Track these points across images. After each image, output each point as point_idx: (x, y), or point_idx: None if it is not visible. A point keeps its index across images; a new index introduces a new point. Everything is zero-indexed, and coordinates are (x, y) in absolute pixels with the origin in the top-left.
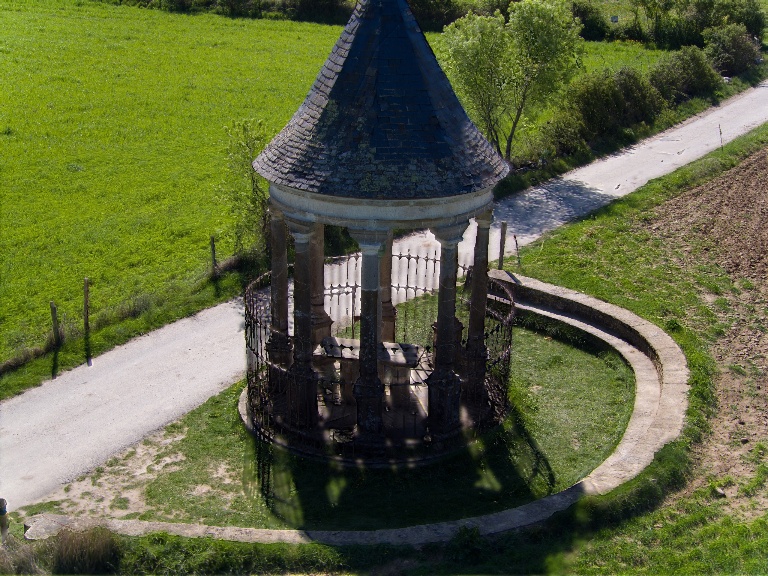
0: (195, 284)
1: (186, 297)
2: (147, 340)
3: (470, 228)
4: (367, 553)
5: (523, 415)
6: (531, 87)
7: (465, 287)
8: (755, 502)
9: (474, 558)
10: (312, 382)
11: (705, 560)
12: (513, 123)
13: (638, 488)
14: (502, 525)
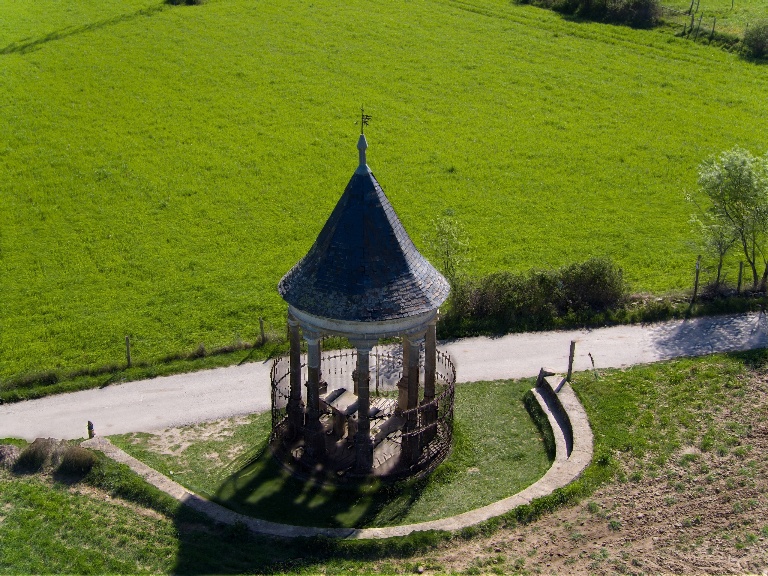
0: None
1: None
2: None
3: (632, 336)
4: (189, 514)
5: (428, 482)
6: None
7: (536, 382)
8: None
9: (230, 539)
10: (298, 413)
11: None
12: None
13: (362, 543)
14: (271, 530)
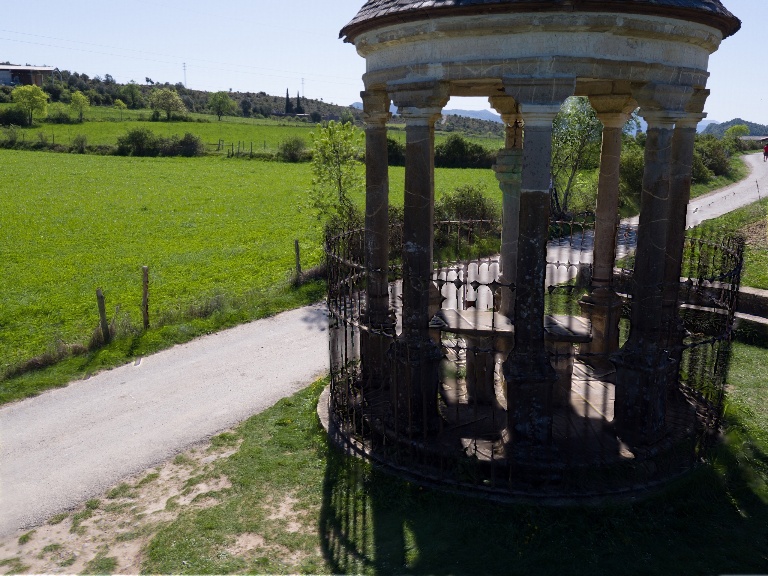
0: (277, 290)
1: (265, 299)
2: (214, 339)
3: (552, 250)
4: None
5: (743, 420)
6: (587, 143)
7: None
8: None
9: None
10: (431, 362)
11: None
12: (569, 178)
13: None
14: None
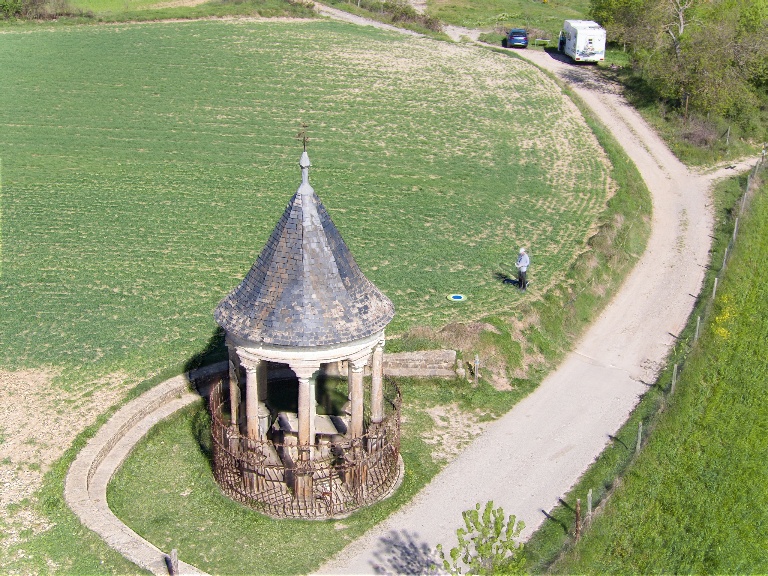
0: None
1: None
2: None
3: None
4: None
5: None
6: None
7: None
8: (108, 380)
9: None
10: None
11: None
12: None
13: None
14: None
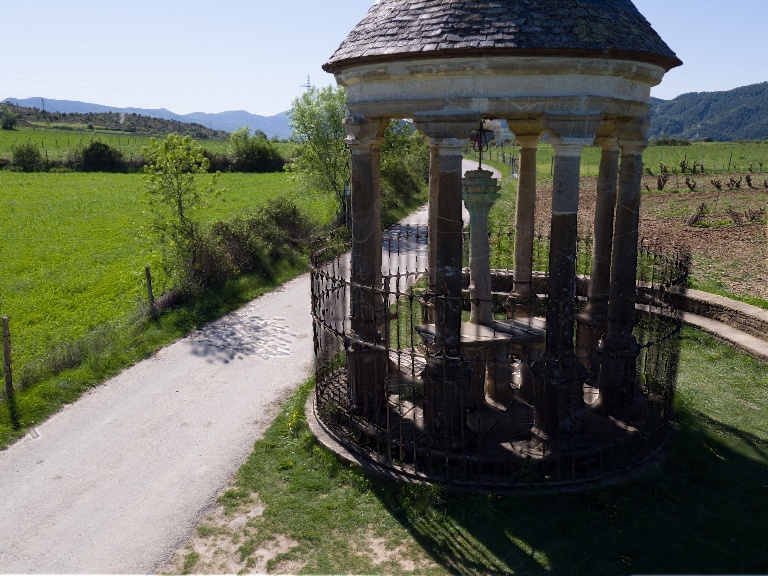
0: (135, 325)
1: None
2: (107, 391)
3: None
4: None
5: None
6: None
7: None
8: None
9: None
10: None
11: None
12: None
13: None
14: None
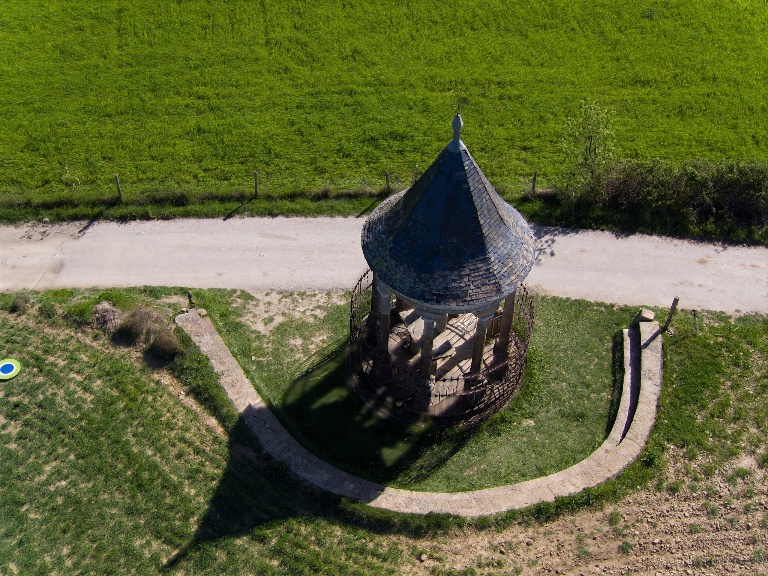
0: (511, 195)
1: None
2: None
3: (766, 267)
4: (244, 436)
5: (479, 432)
6: None
7: None
8: None
9: None
10: None
11: (341, 572)
12: None
13: (379, 517)
14: (308, 475)
